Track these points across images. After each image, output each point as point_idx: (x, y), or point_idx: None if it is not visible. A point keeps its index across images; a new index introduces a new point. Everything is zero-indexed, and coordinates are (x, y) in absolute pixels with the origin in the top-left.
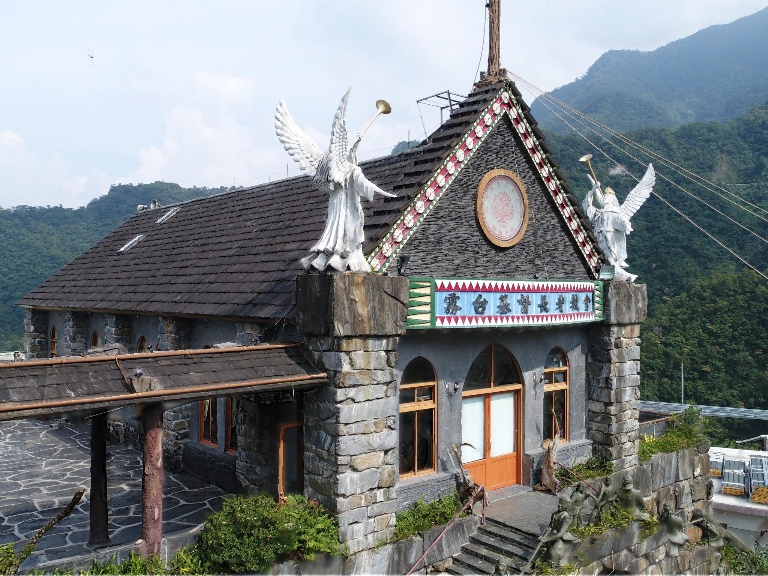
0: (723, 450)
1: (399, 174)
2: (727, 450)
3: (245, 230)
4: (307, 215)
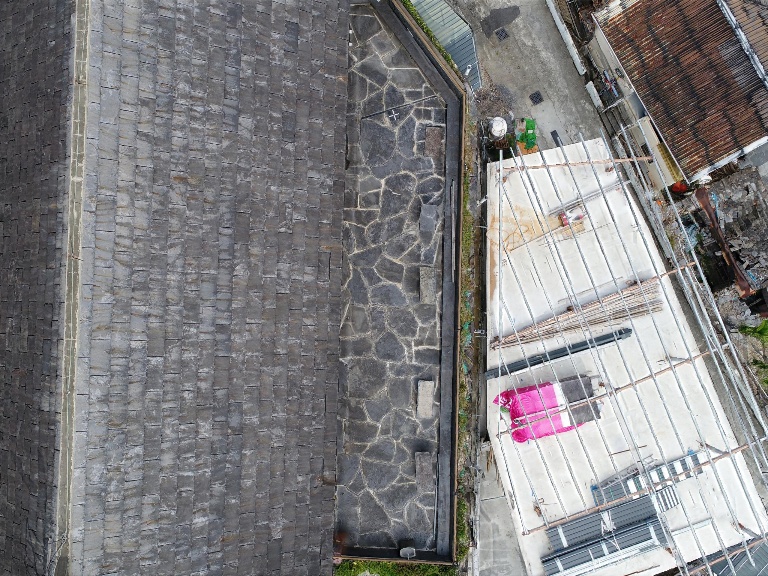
0: (724, 461)
1: (25, 572)
2: (728, 465)
3: (0, 339)
4: (1, 457)
